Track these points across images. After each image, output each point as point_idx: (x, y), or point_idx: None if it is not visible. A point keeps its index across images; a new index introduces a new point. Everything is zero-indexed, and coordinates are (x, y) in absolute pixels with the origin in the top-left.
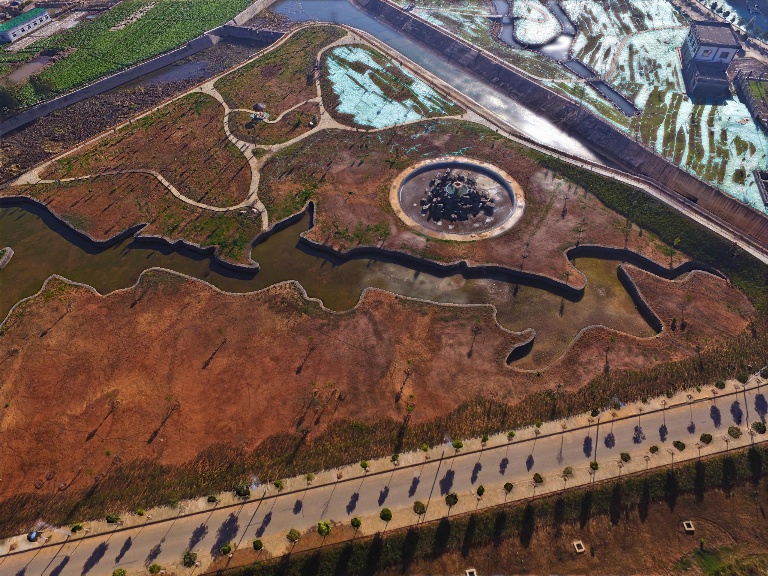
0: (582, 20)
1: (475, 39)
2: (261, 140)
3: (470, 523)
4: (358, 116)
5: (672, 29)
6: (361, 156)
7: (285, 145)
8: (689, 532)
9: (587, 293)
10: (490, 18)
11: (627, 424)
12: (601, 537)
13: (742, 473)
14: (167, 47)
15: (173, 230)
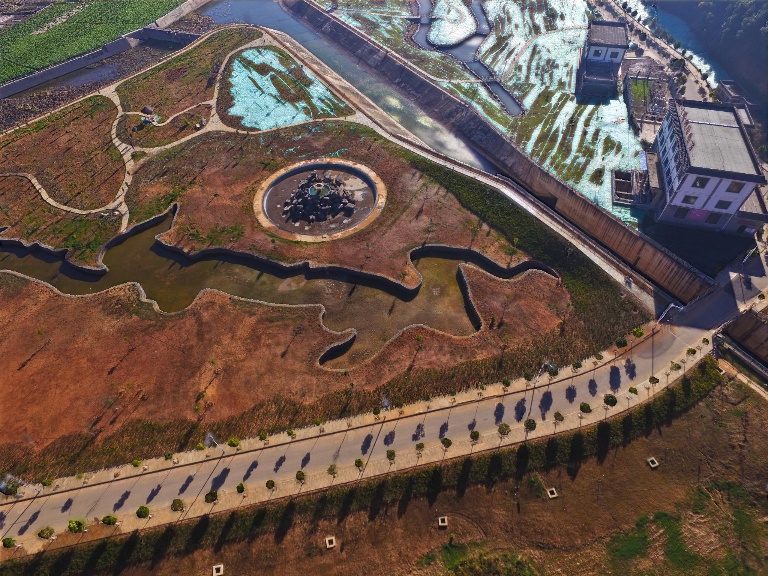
0: (498, 20)
1: (387, 40)
2: (144, 143)
3: (229, 520)
4: (247, 118)
5: (580, 29)
6: (237, 158)
7: (166, 148)
8: (442, 527)
9: (421, 293)
10: (408, 19)
11: (411, 422)
12: (355, 533)
13: (507, 469)
14: (82, 50)
15: (32, 233)
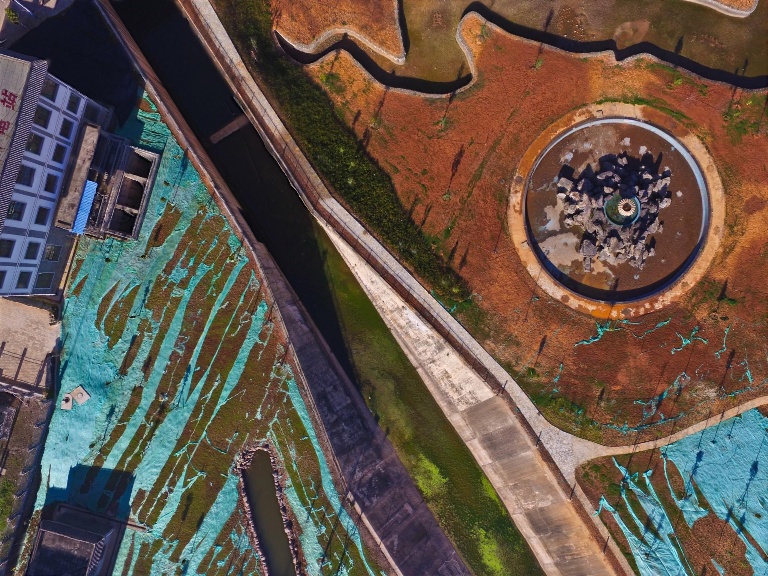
0: None
1: None
2: None
3: None
4: None
5: None
6: None
7: None
8: None
9: (458, 17)
10: None
11: None
12: None
13: None
14: None
15: None
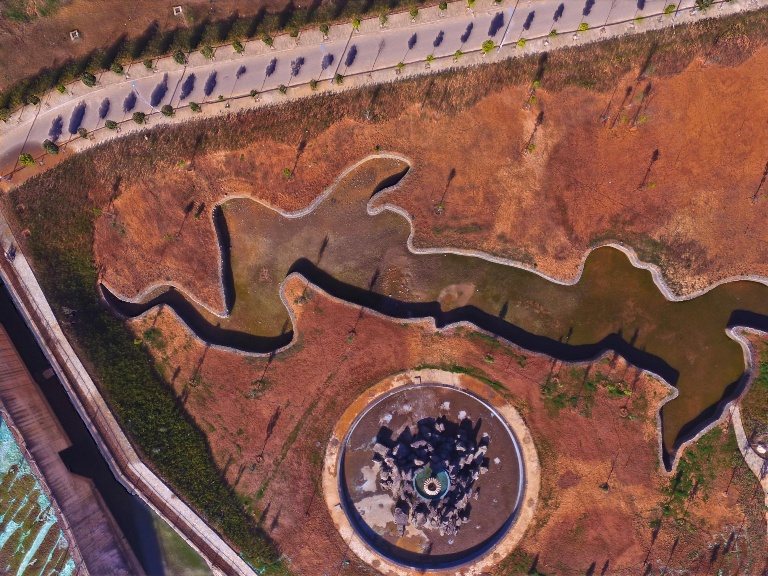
0: None
1: None
2: None
3: None
4: None
5: None
6: None
7: None
8: None
9: (284, 273)
10: None
11: (304, 78)
12: None
13: (214, 26)
14: None
15: None
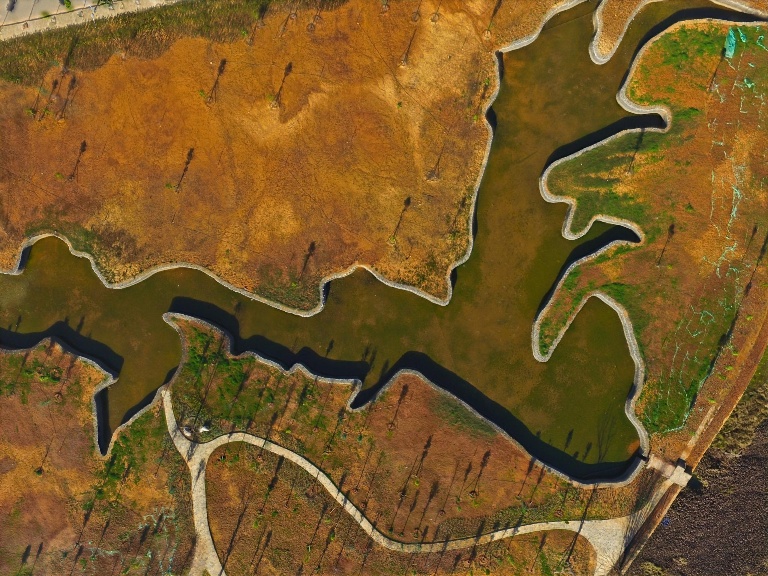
0: None
1: None
2: None
3: None
4: None
5: None
6: (26, 575)
7: None
8: None
9: None
10: None
11: None
12: None
13: None
14: None
15: (304, 392)
